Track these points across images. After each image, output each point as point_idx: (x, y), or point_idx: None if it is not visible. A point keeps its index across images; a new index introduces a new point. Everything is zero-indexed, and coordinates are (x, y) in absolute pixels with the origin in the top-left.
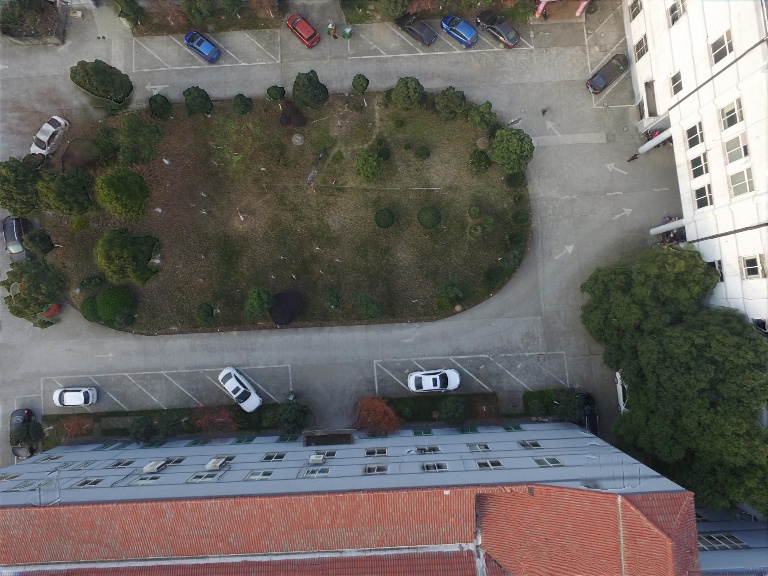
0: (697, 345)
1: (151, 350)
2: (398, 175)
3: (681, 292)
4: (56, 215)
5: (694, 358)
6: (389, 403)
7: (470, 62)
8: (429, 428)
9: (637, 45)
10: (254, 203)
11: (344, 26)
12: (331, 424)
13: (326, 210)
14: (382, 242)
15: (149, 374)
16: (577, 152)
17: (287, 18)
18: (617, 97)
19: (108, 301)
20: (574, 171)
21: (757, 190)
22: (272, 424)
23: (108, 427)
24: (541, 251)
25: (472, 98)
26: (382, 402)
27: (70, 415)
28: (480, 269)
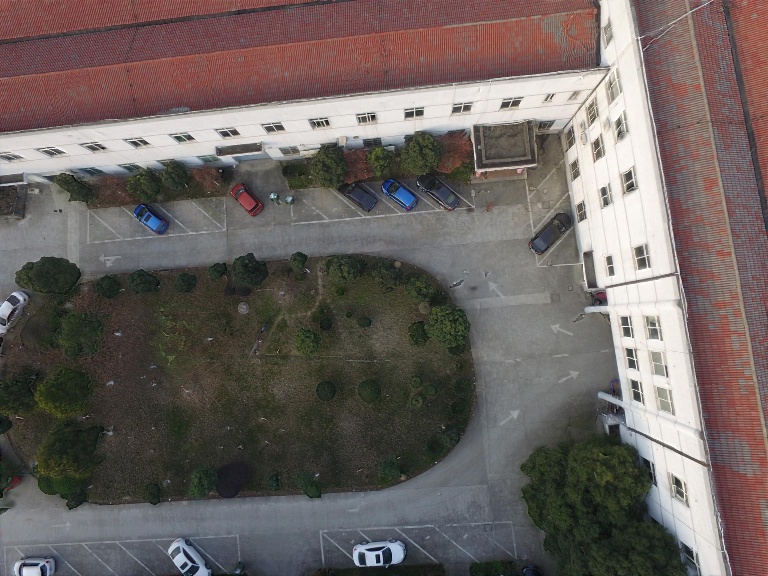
0: None
1: (106, 520)
2: (341, 342)
3: (610, 503)
4: None
5: None
6: None
7: (411, 224)
8: None
9: (578, 207)
10: (202, 373)
11: (287, 192)
12: None
13: (271, 379)
14: (326, 411)
15: (104, 544)
16: (521, 313)
17: (232, 186)
18: (561, 255)
19: (62, 478)
20: (518, 333)
21: (678, 417)
22: None
23: None
24: (486, 417)
25: (414, 261)
26: None
27: None
28: (424, 437)
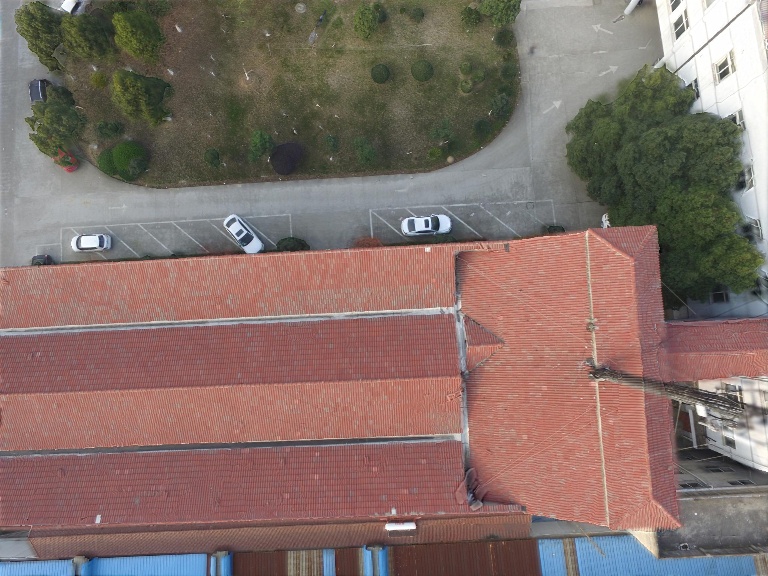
0: (670, 139)
1: (162, 202)
2: (394, 38)
3: (657, 103)
4: (77, 80)
5: (667, 151)
6: None
7: None
8: None
9: None
10: (259, 66)
11: None
12: None
13: (326, 71)
14: (378, 99)
15: (160, 224)
16: (565, 15)
17: None
18: None
19: (123, 151)
20: (562, 32)
21: None
22: None
23: None
24: (530, 106)
25: None
26: None
27: None
28: (471, 123)
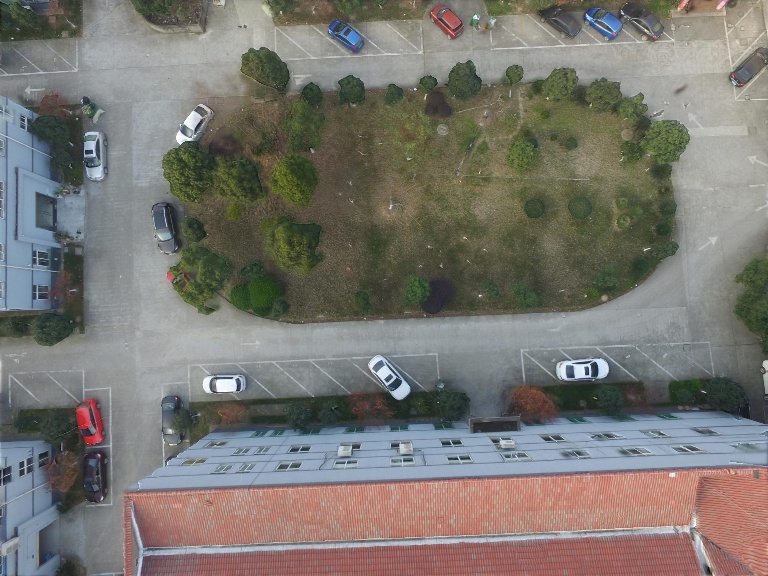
0: None
1: (298, 338)
2: (543, 166)
3: None
4: (201, 203)
5: None
6: None
7: (612, 54)
8: (580, 416)
9: None
10: (400, 192)
11: (486, 17)
12: (480, 412)
13: (472, 200)
14: (528, 232)
15: (296, 362)
16: (719, 144)
17: (429, 9)
18: (758, 90)
19: (261, 289)
20: (717, 163)
21: None
22: (424, 412)
23: (256, 414)
24: (685, 242)
25: None
26: None
27: (217, 402)
28: (626, 259)
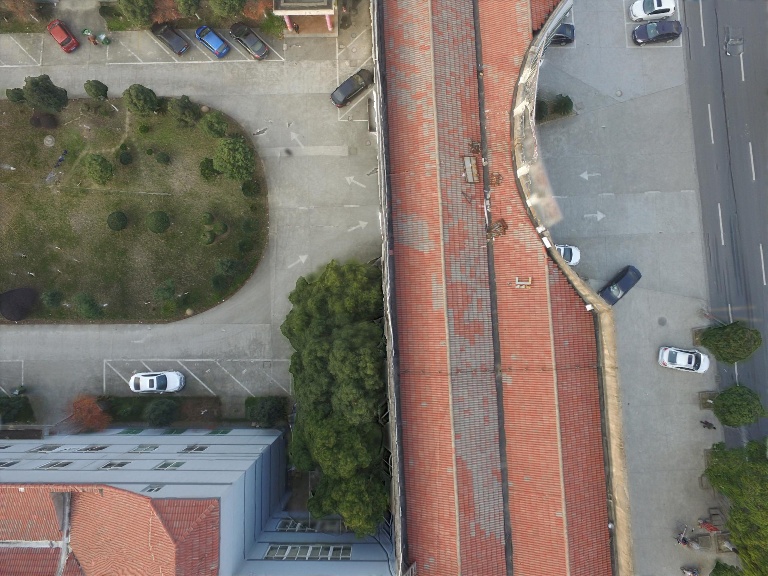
0: (323, 358)
1: None
2: (141, 179)
3: (336, 305)
4: None
5: (319, 370)
6: (112, 402)
7: (222, 72)
8: (145, 428)
9: None
10: (1, 201)
11: (105, 33)
12: (56, 420)
13: (69, 211)
14: (120, 244)
15: None
16: (319, 164)
17: None
18: (362, 111)
19: None
20: (314, 182)
21: None
22: None
23: None
24: (275, 260)
25: (221, 107)
26: (100, 401)
27: None
28: (213, 275)
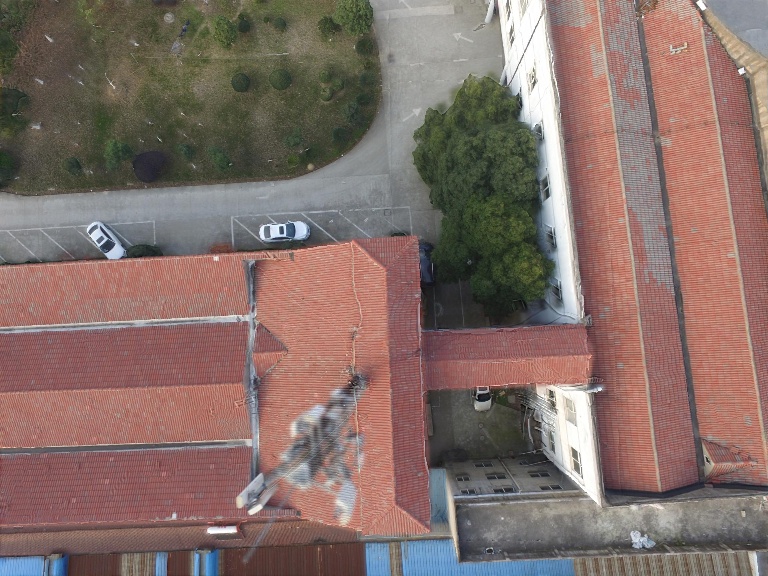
0: (477, 149)
1: (31, 209)
2: (258, 47)
3: (478, 113)
4: None
5: (474, 160)
6: None
7: None
8: None
9: None
10: (127, 75)
11: None
12: None
13: (192, 80)
14: (241, 107)
15: (28, 230)
16: (426, 23)
17: None
18: None
19: None
20: (423, 40)
21: (529, 1)
22: None
23: None
24: (390, 114)
25: None
26: None
27: None
28: (331, 131)
